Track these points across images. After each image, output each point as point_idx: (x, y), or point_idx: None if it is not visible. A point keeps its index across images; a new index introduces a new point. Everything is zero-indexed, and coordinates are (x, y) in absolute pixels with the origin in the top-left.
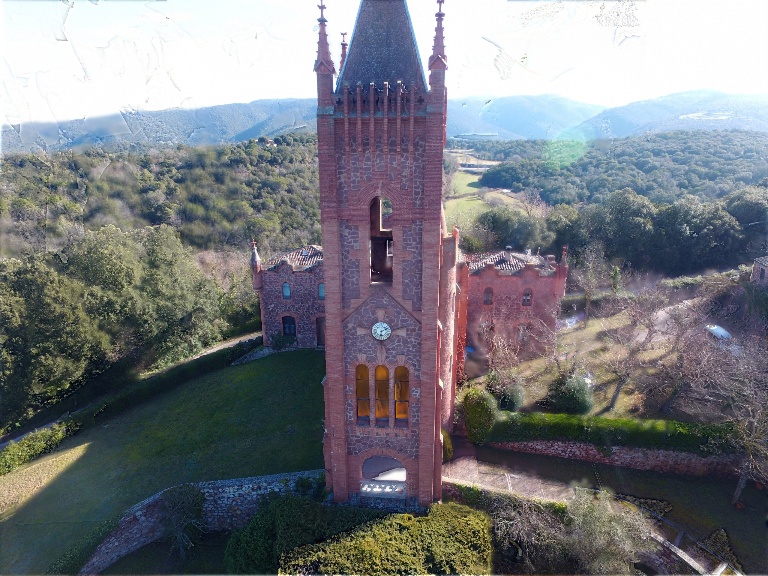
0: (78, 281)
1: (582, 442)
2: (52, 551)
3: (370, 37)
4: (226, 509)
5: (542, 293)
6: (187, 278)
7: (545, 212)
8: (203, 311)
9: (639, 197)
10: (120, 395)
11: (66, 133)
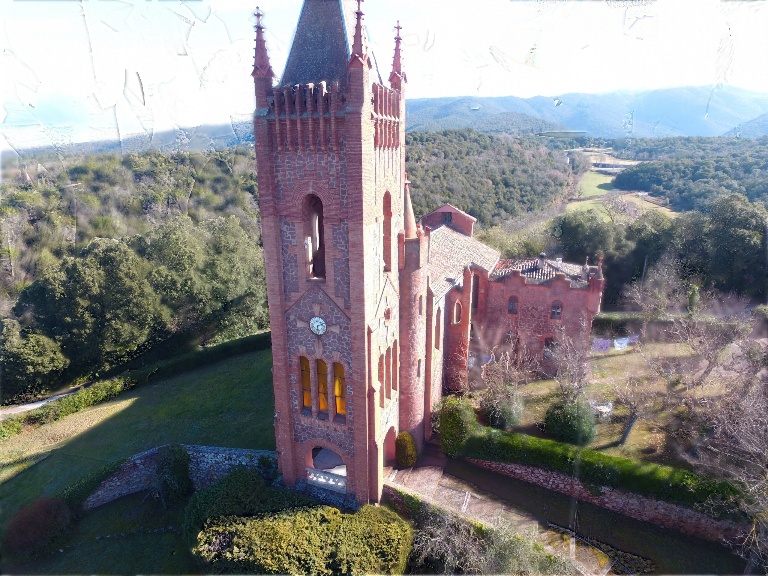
0: (155, 261)
1: (566, 474)
2: (75, 479)
3: (308, 40)
4: (206, 472)
5: (573, 307)
6: (247, 265)
7: (633, 218)
8: (254, 296)
9: (752, 205)
10: (171, 361)
11: (188, 134)
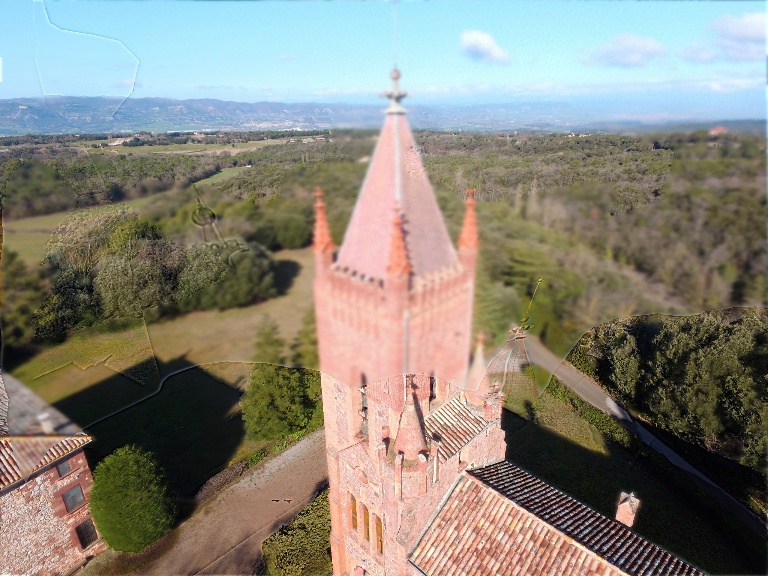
0: None
1: None
2: None
3: None
4: None
5: None
6: None
7: None
8: None
9: None
10: (663, 463)
11: None
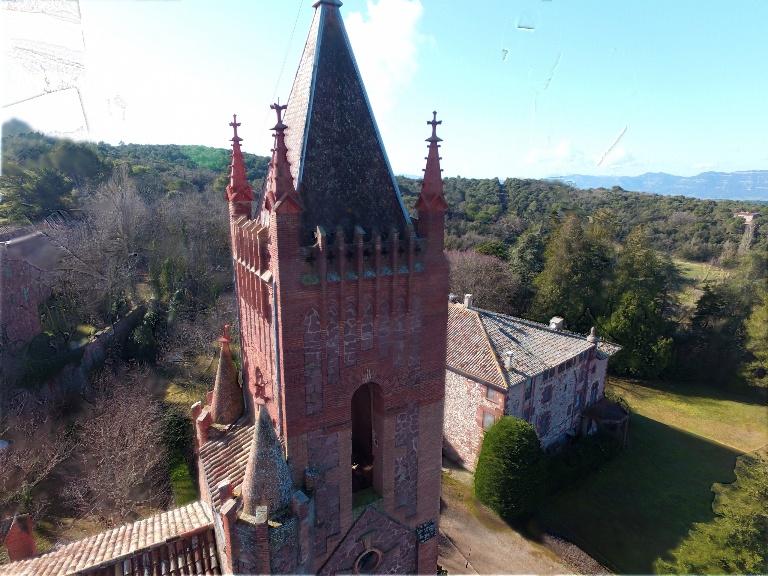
0: None
1: None
2: None
3: None
4: None
5: None
6: None
7: None
8: None
9: None
10: None
11: None
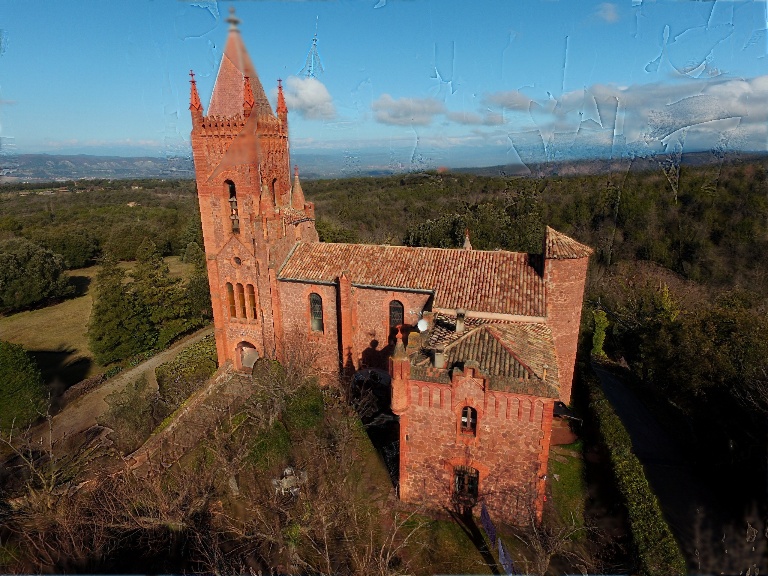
0: None
1: None
2: None
3: None
4: None
5: None
6: None
7: None
8: None
9: None
10: None
11: None
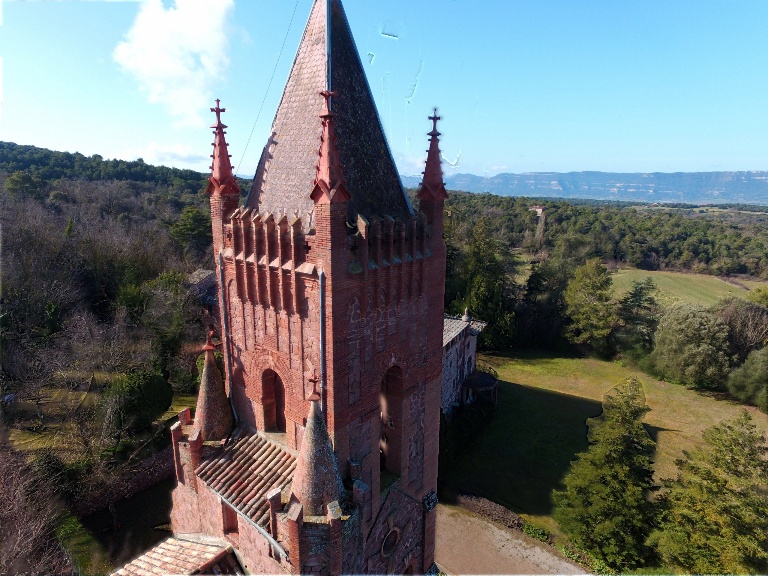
0: None
1: None
2: None
3: None
4: None
5: None
6: None
7: None
8: None
9: None
10: None
11: None
